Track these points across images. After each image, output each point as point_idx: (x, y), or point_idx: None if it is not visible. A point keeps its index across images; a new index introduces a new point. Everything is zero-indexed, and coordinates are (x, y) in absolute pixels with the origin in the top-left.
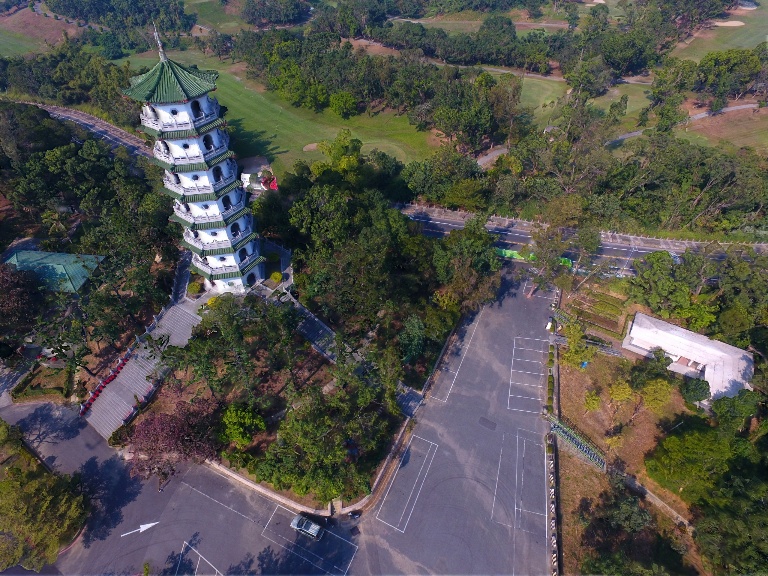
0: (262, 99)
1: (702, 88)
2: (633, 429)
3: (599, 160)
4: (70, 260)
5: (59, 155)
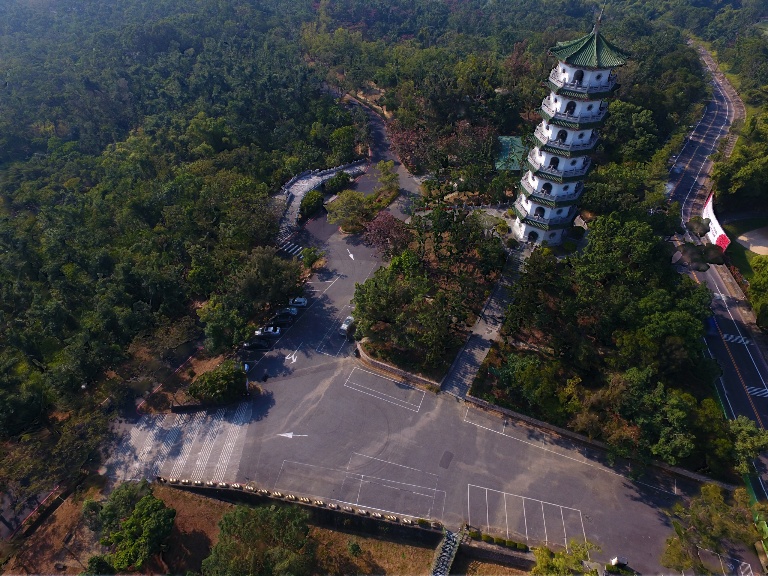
0: None
1: None
2: None
3: None
4: None
5: (619, 107)
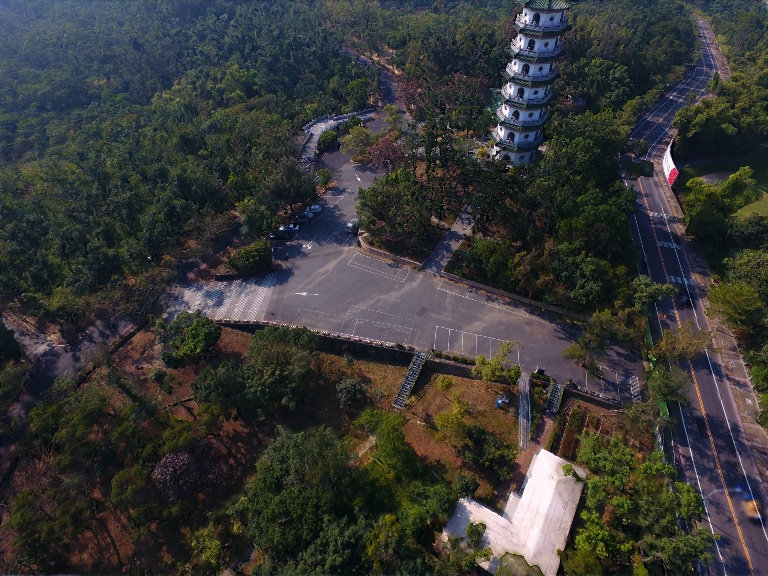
0: None
1: None
2: None
3: None
4: None
5: (598, 63)
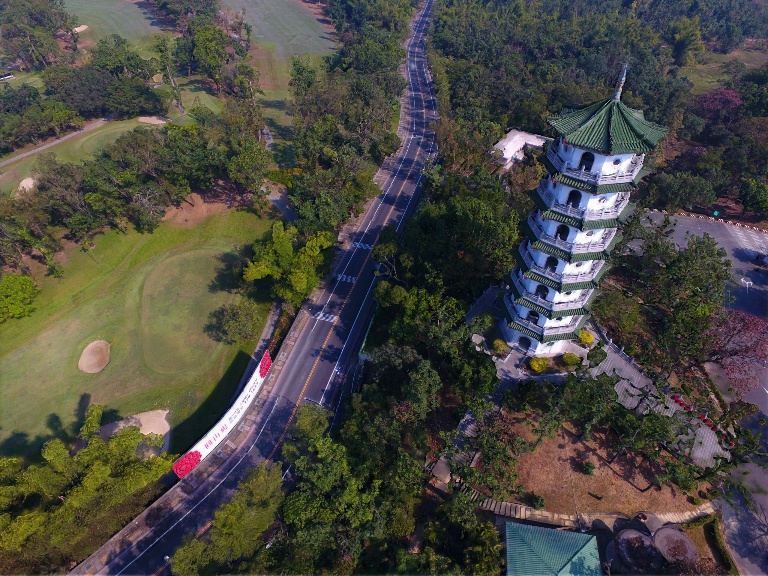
0: None
1: (191, 70)
2: None
3: None
4: (535, 575)
5: None
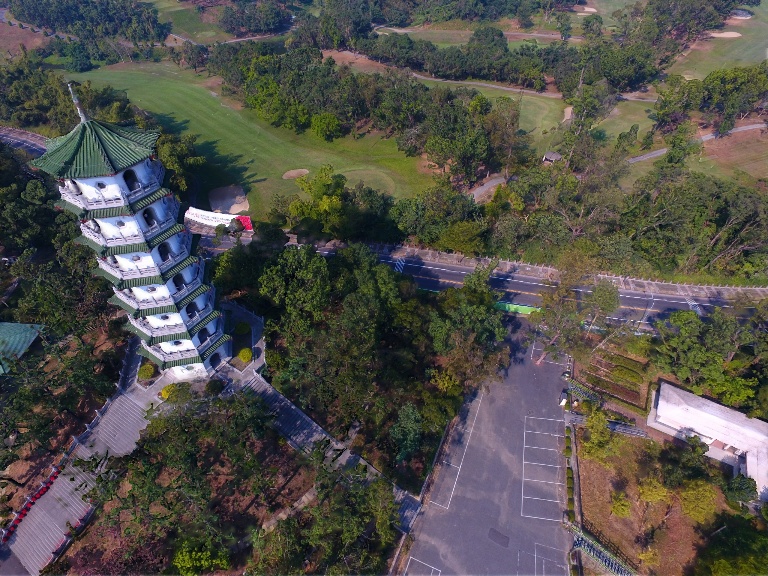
0: (239, 118)
1: (705, 106)
2: (667, 533)
3: (612, 202)
4: (2, 332)
5: None
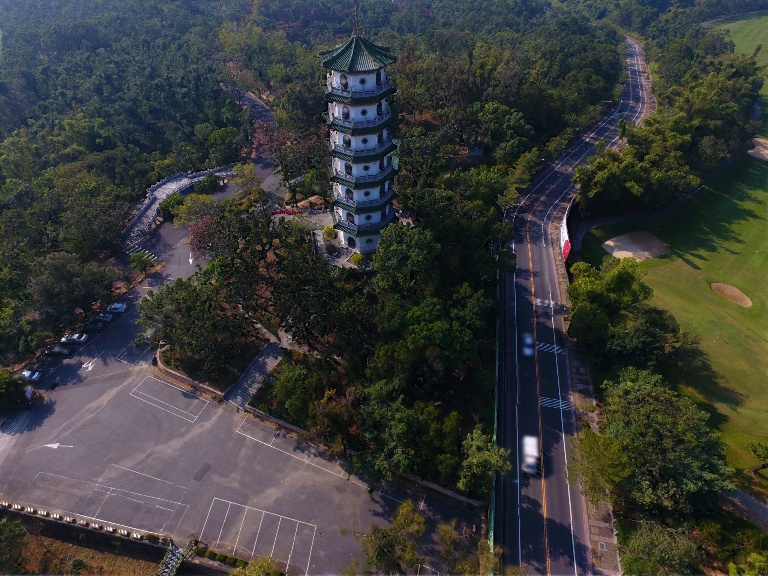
0: None
1: None
2: None
3: None
4: None
5: (491, 109)
